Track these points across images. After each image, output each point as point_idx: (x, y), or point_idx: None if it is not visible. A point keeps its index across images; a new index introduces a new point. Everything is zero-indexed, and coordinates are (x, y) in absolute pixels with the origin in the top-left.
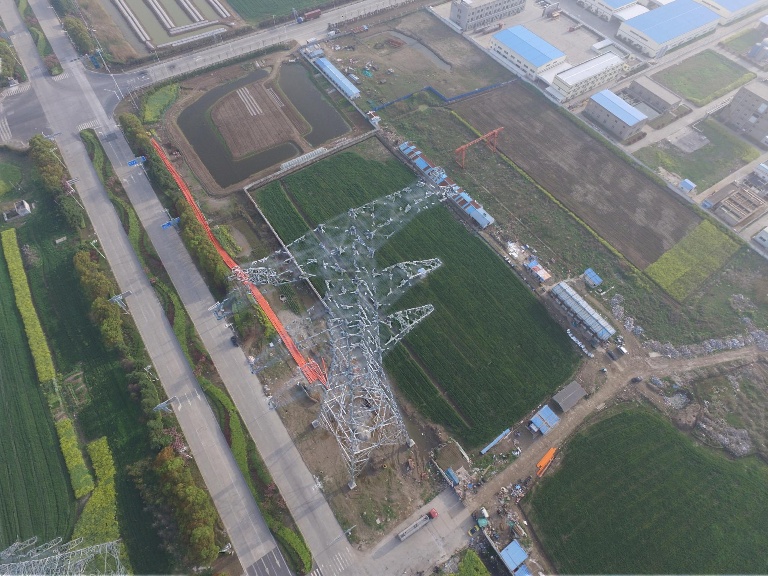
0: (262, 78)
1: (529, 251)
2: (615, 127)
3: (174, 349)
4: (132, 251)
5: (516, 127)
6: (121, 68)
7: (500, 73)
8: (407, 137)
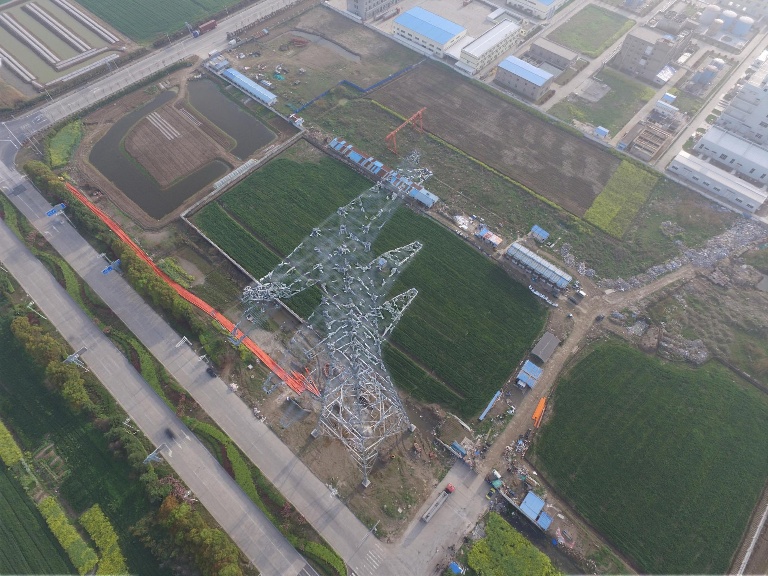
0: (170, 99)
1: (477, 221)
2: (526, 89)
3: (148, 396)
4: (75, 305)
5: (436, 105)
6: (10, 114)
7: (409, 56)
8: (335, 133)
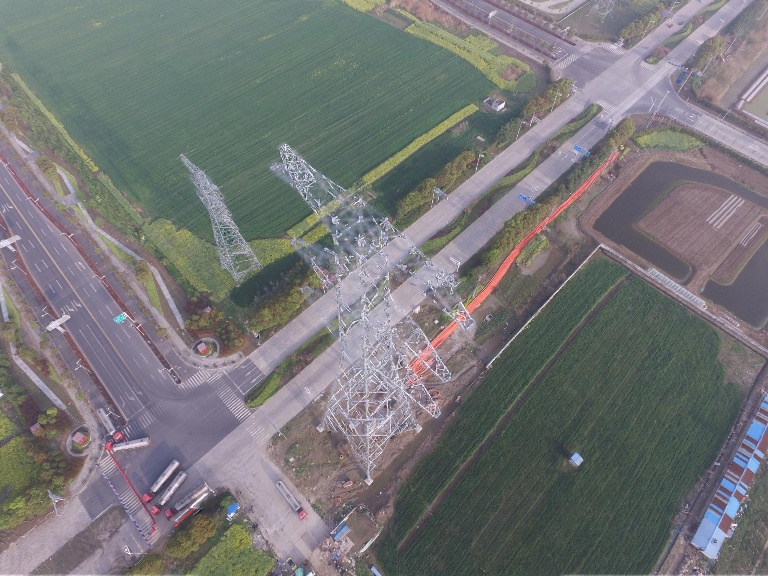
0: None
1: None
2: None
3: None
4: (490, 186)
5: None
6: (690, 97)
7: None
8: None
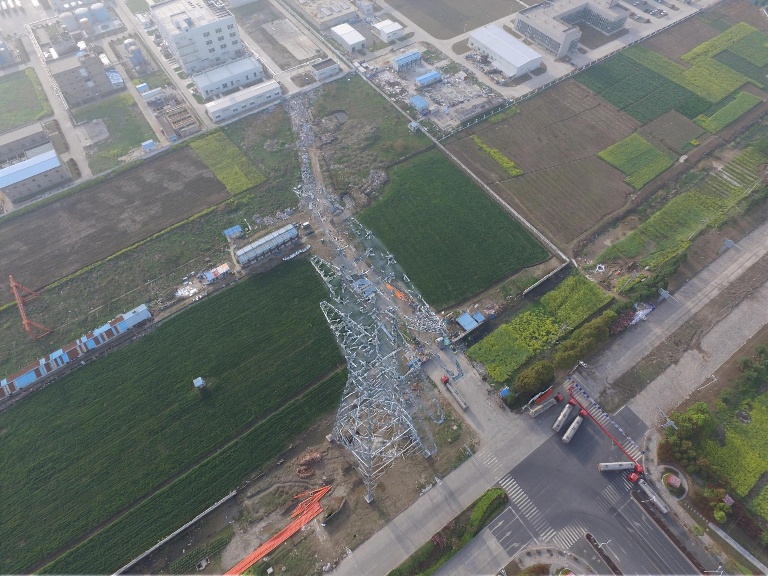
0: None
1: (191, 278)
2: (52, 179)
3: None
4: None
5: (6, 268)
6: None
7: None
8: None
